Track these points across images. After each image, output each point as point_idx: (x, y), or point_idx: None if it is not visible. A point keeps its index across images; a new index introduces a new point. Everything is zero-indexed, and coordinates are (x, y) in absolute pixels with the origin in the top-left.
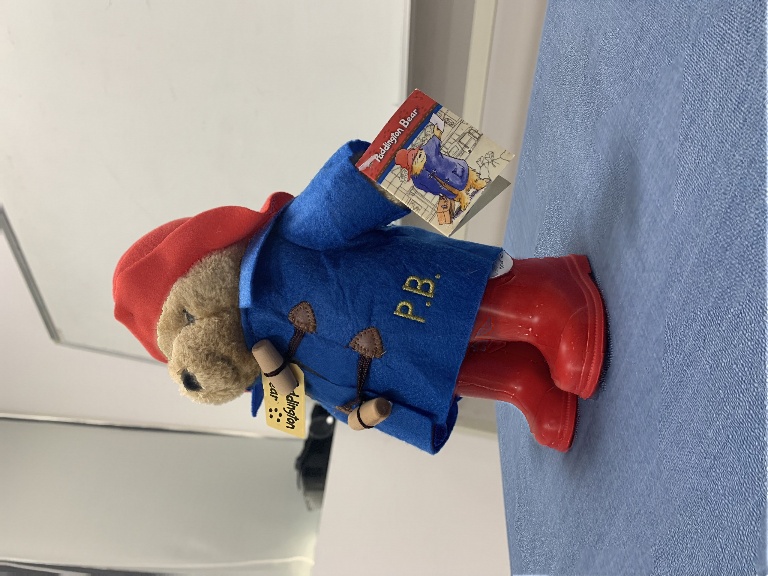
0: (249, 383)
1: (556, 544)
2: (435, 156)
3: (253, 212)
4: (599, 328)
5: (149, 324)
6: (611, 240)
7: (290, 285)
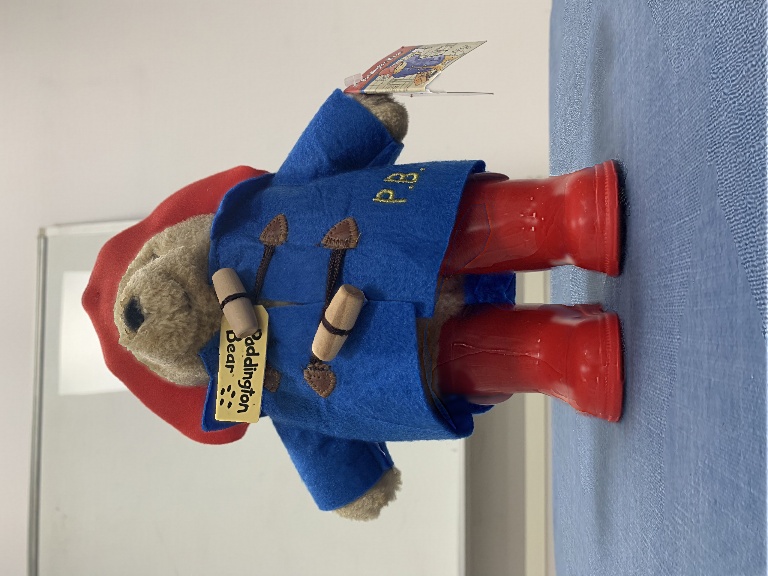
0: (202, 336)
1: (643, 570)
2: (415, 60)
3: (246, 167)
4: (607, 162)
5: (112, 297)
6: (604, 109)
7: (268, 208)
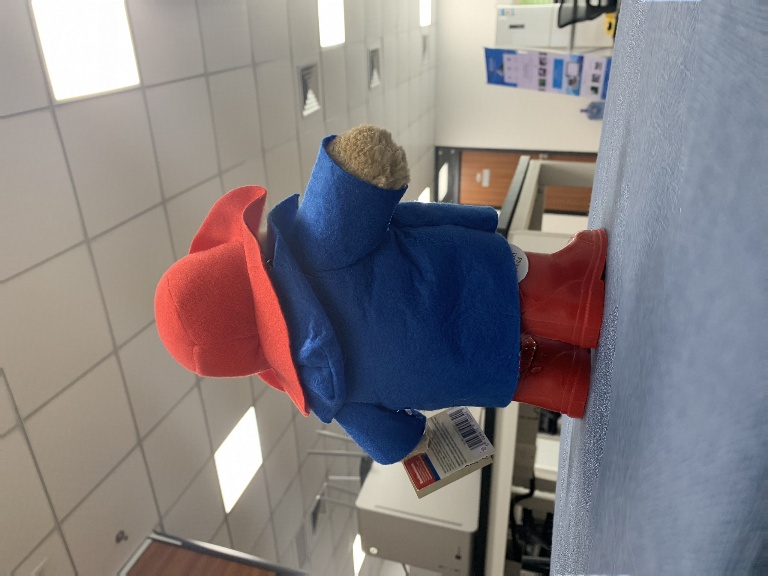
0: None
1: None
2: None
3: None
4: None
5: None
6: None
7: None
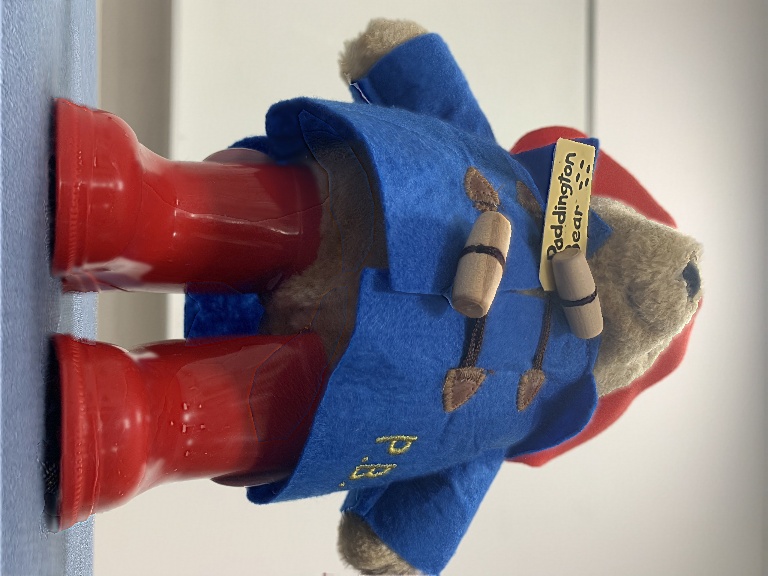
0: (611, 253)
1: None
2: None
3: None
4: None
5: None
6: None
7: None
